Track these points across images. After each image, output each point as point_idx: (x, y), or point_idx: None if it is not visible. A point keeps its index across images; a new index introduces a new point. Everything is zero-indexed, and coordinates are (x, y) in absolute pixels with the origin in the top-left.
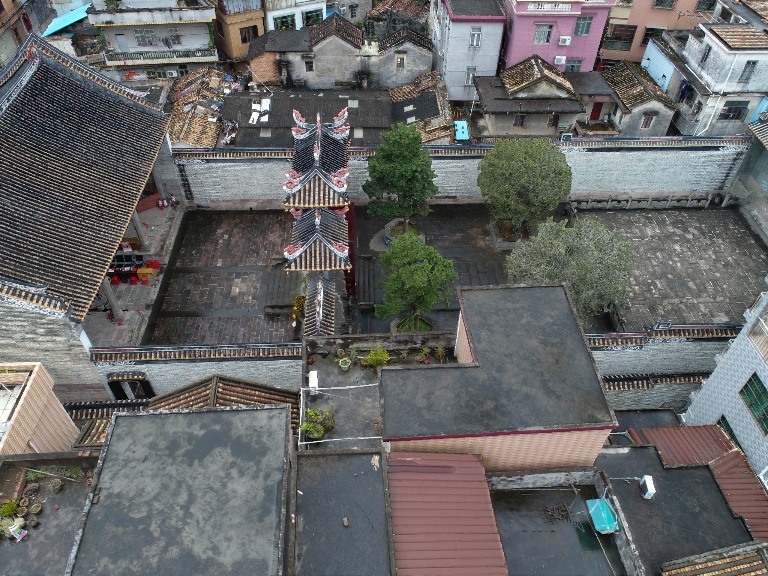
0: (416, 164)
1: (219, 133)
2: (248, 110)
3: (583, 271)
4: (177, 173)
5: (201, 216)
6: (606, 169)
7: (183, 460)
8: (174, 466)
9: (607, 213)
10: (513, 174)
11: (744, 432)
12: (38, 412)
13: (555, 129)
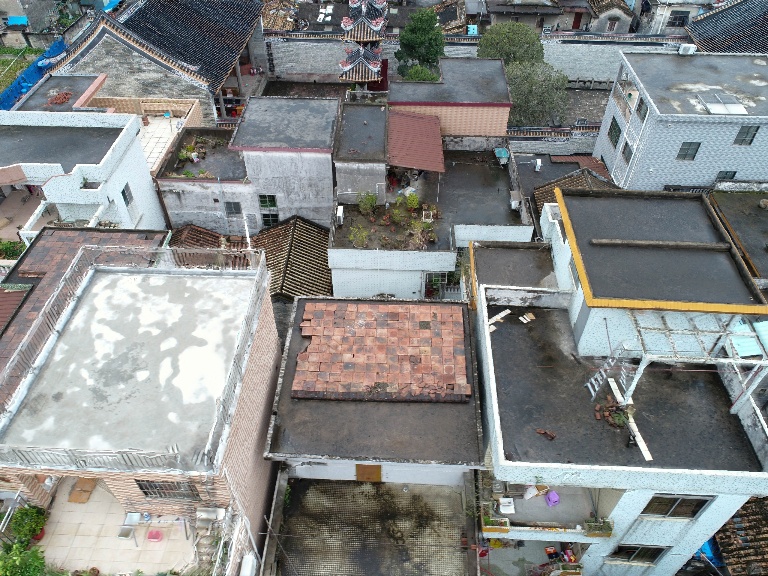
0: (432, 34)
1: (295, 29)
2: (317, 12)
3: (530, 84)
4: (265, 49)
5: (279, 84)
6: (577, 59)
7: (285, 112)
8: (280, 113)
9: (575, 91)
10: (499, 43)
11: (608, 156)
12: (196, 126)
13: (541, 30)
